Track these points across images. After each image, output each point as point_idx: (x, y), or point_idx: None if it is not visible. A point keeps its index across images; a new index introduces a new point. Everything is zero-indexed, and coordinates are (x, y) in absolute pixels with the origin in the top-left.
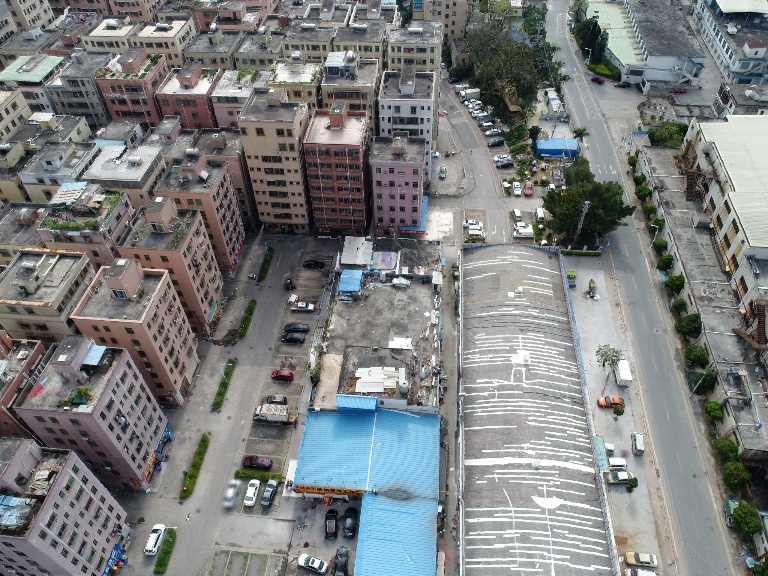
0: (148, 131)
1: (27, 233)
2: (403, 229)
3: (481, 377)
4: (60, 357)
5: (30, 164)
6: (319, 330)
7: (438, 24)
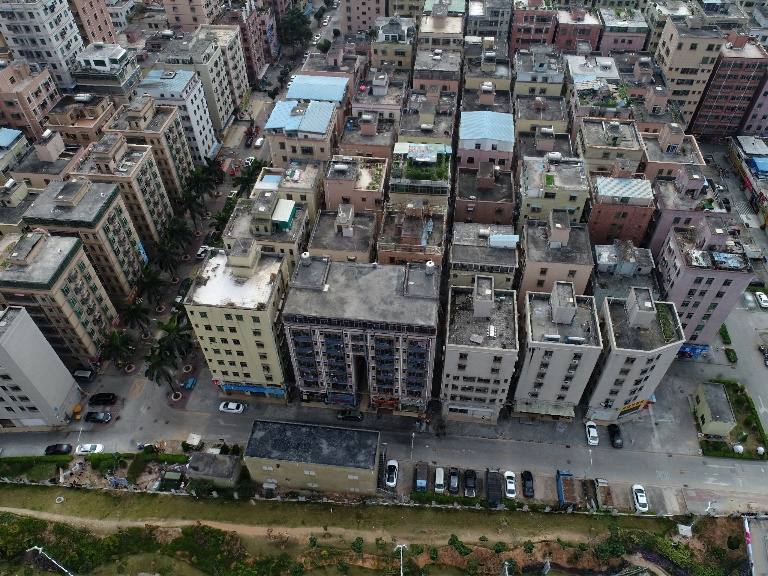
0: (562, 52)
1: (547, 114)
2: (767, 135)
3: None
4: (694, 176)
5: (519, 67)
6: (738, 203)
7: None
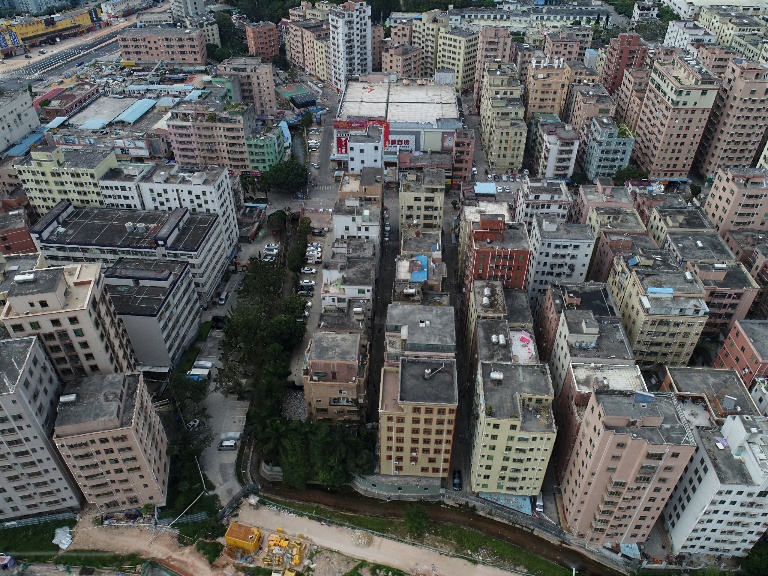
0: None
1: None
2: None
3: None
4: None
5: None
6: None
7: (707, 7)
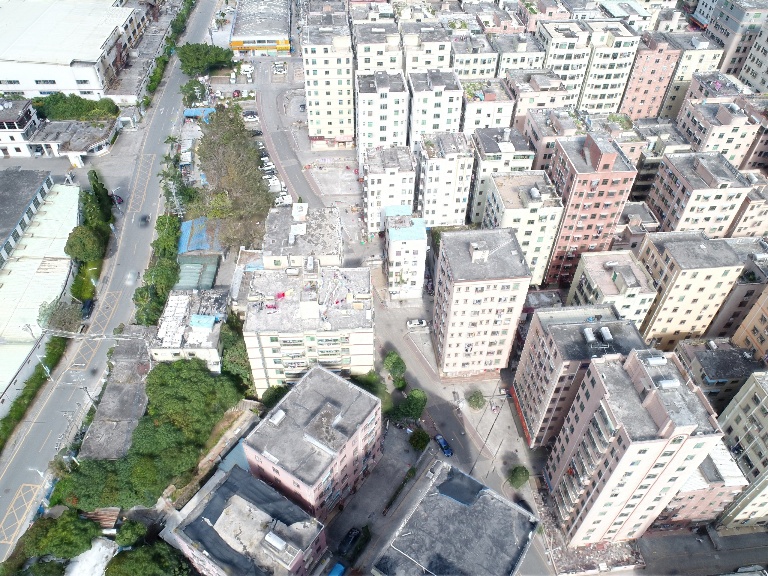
0: None
1: None
2: None
3: (281, 6)
4: None
5: None
6: None
7: (306, 43)
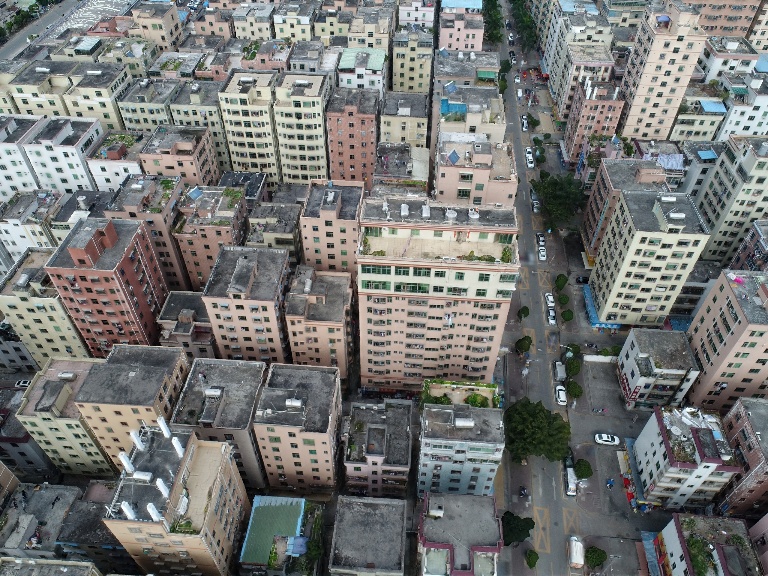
0: None
1: None
2: None
3: None
4: None
5: None
6: None
7: None
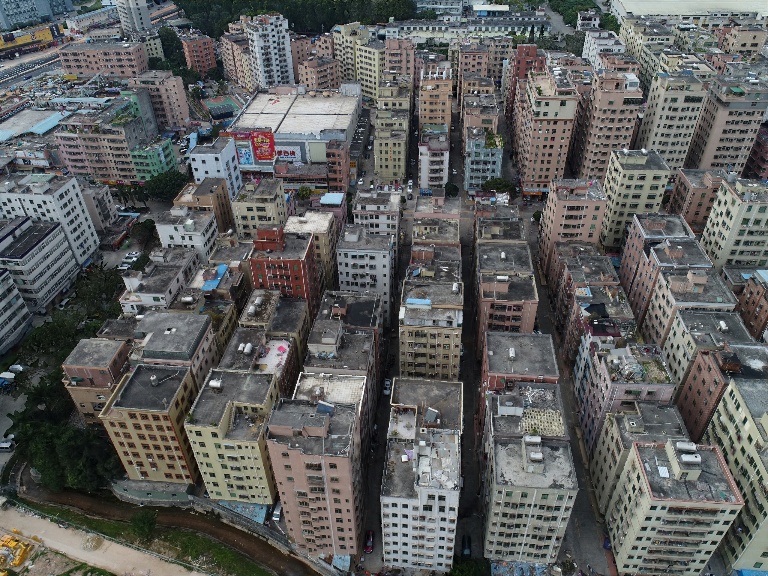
0: None
1: None
2: None
3: None
4: None
5: None
6: None
7: None
